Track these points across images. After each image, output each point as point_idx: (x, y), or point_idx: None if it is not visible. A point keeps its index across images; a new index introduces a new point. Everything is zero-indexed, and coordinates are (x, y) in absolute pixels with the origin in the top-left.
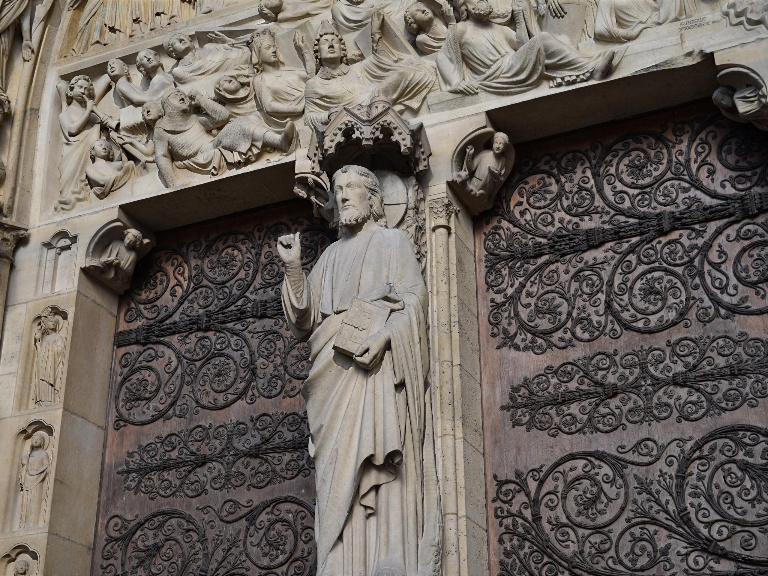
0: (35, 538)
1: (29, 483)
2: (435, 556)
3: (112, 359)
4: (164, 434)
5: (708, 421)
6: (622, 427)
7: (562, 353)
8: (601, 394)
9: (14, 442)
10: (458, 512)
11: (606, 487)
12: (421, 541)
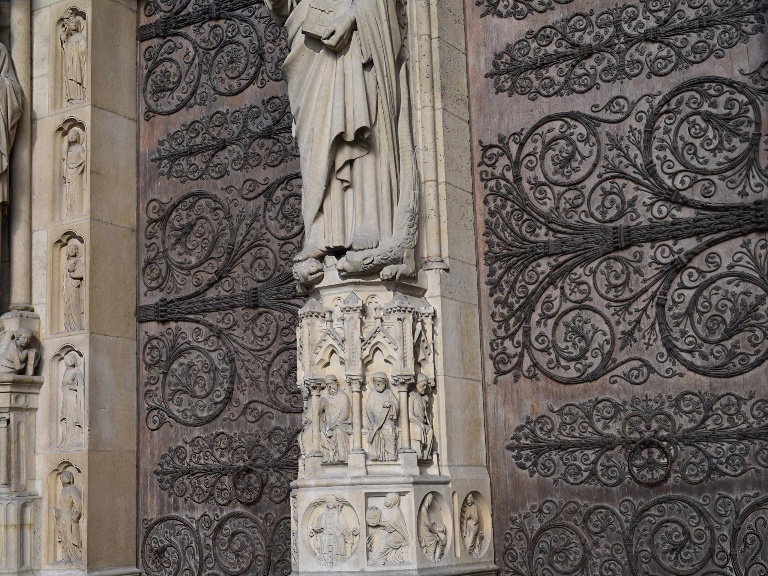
0: (80, 224)
1: (70, 176)
2: (409, 221)
3: (137, 54)
4: (188, 122)
5: (676, 75)
6: (596, 87)
7: (542, 17)
8: (577, 55)
9: (53, 139)
10: (438, 179)
11: (580, 146)
12: (397, 208)
